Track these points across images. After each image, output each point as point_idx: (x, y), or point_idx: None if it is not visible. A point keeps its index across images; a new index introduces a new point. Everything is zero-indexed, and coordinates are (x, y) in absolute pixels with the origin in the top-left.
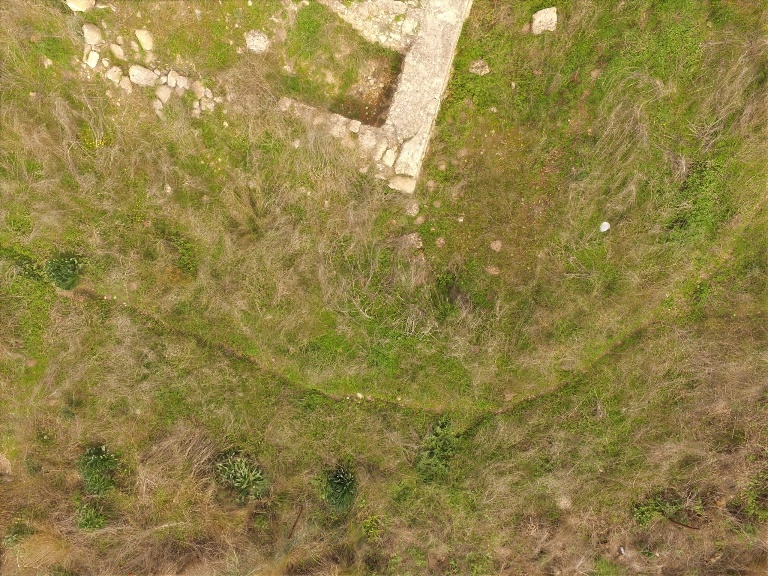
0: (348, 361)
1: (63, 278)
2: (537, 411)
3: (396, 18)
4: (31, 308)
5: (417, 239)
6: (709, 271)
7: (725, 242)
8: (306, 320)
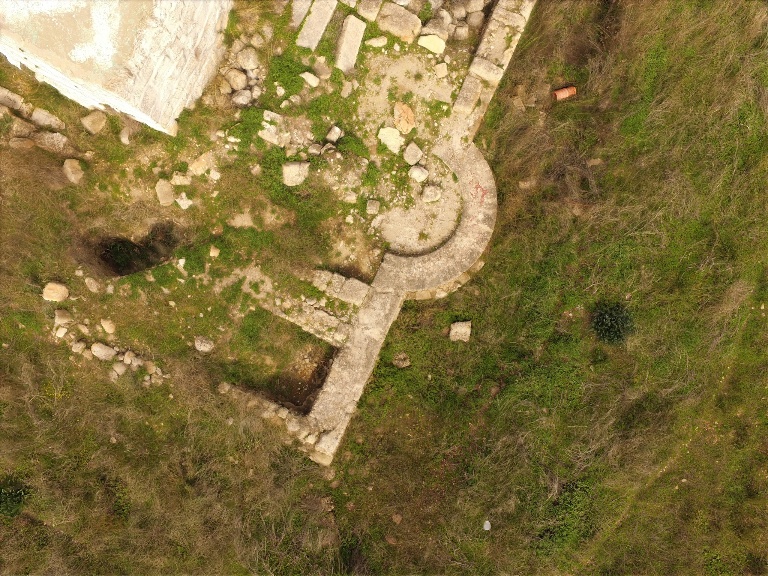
0: None
1: (8, 509)
2: None
3: (329, 329)
4: None
5: (330, 502)
6: (573, 572)
7: (587, 552)
8: (219, 575)
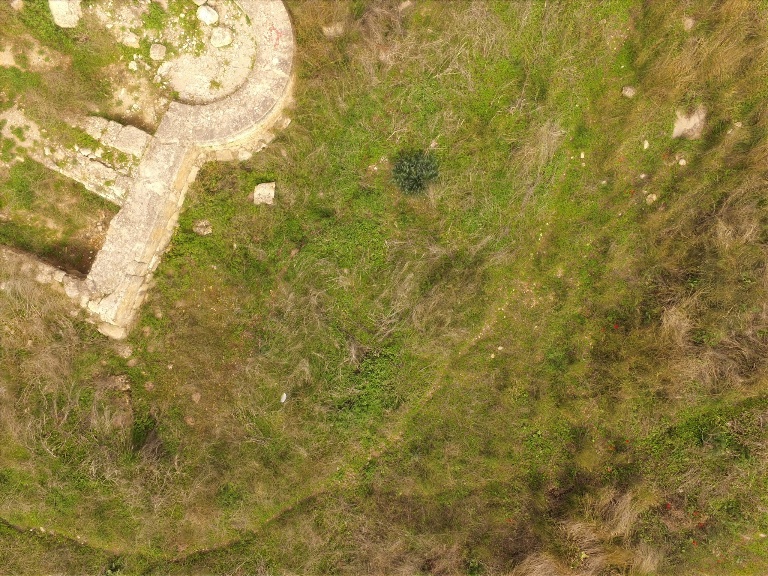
0: (29, 497)
1: None
2: (205, 565)
3: (106, 183)
4: None
5: (124, 381)
6: (380, 450)
7: (394, 425)
8: None
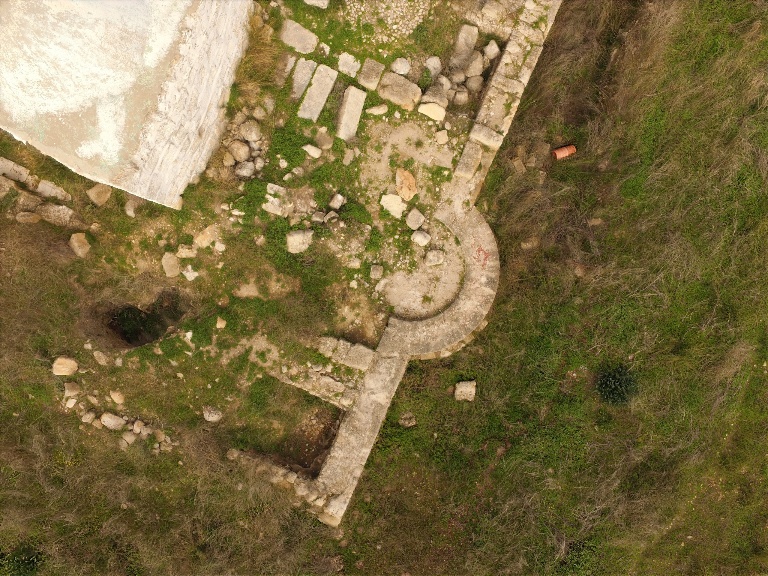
0: None
1: None
2: None
3: (335, 395)
4: None
5: (339, 562)
6: None
7: None
8: None
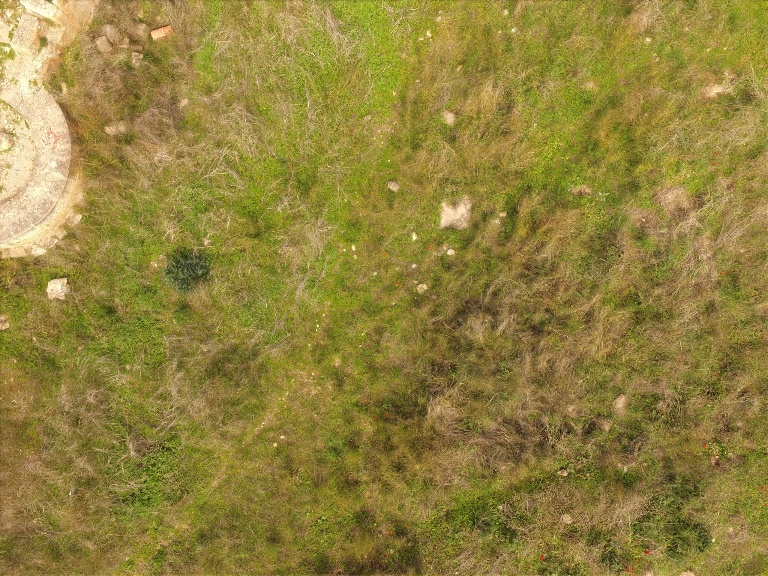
0: None
1: None
2: None
3: None
4: None
5: None
6: (168, 539)
7: (179, 516)
8: None
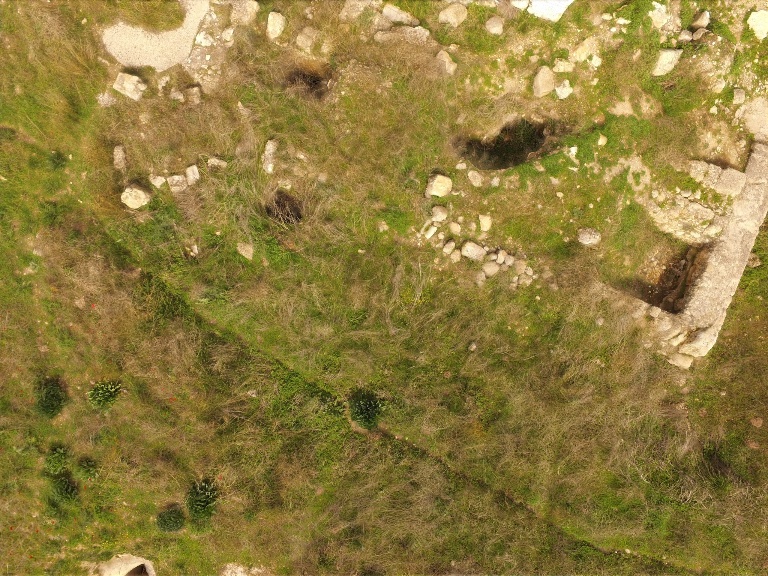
0: (625, 521)
1: (369, 421)
2: None
3: (704, 223)
4: (327, 441)
5: (684, 408)
6: None
7: None
8: None
